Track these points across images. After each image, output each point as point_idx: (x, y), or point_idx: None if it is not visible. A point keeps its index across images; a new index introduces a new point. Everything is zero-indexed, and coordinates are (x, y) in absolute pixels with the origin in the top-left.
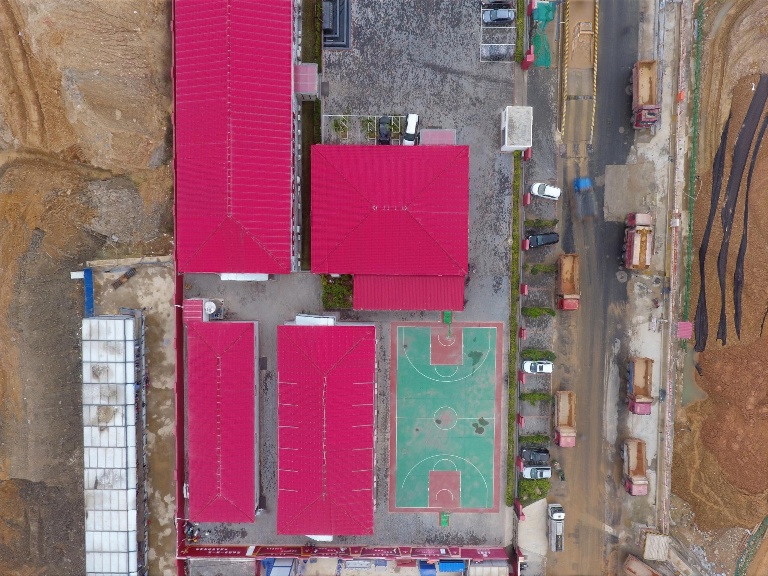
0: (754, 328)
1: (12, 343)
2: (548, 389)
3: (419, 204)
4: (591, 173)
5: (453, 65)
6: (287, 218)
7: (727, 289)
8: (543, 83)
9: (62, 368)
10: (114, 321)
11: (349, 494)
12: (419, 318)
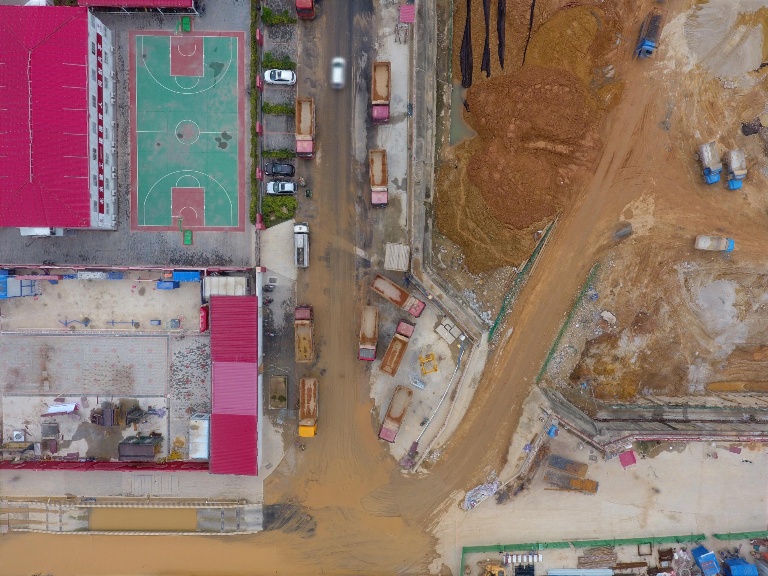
0: (517, 57)
1: None
2: (294, 104)
3: None
4: None
5: None
6: None
7: (491, 20)
8: None
9: None
10: None
11: (61, 180)
12: (158, 27)
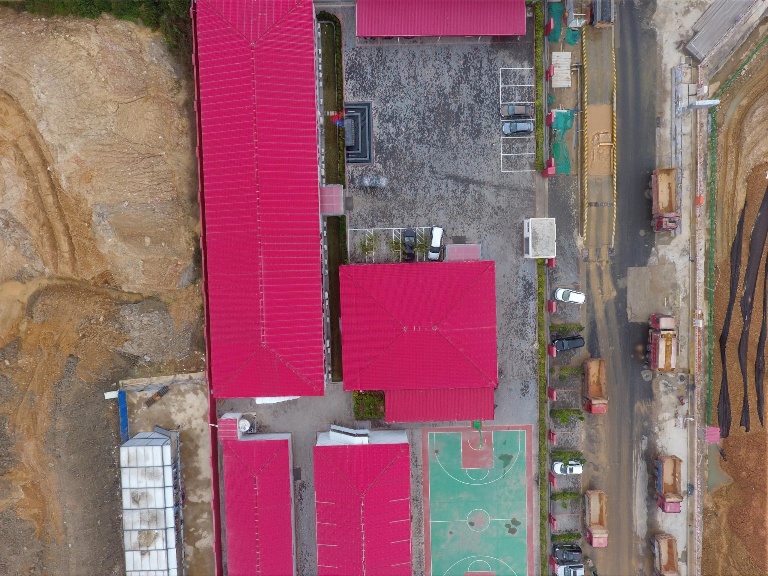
0: None
1: (50, 469)
2: (578, 487)
3: (448, 323)
4: (613, 276)
5: (475, 176)
6: (319, 342)
7: (749, 377)
8: (564, 190)
9: (99, 488)
10: (152, 448)
11: None
12: (449, 424)
